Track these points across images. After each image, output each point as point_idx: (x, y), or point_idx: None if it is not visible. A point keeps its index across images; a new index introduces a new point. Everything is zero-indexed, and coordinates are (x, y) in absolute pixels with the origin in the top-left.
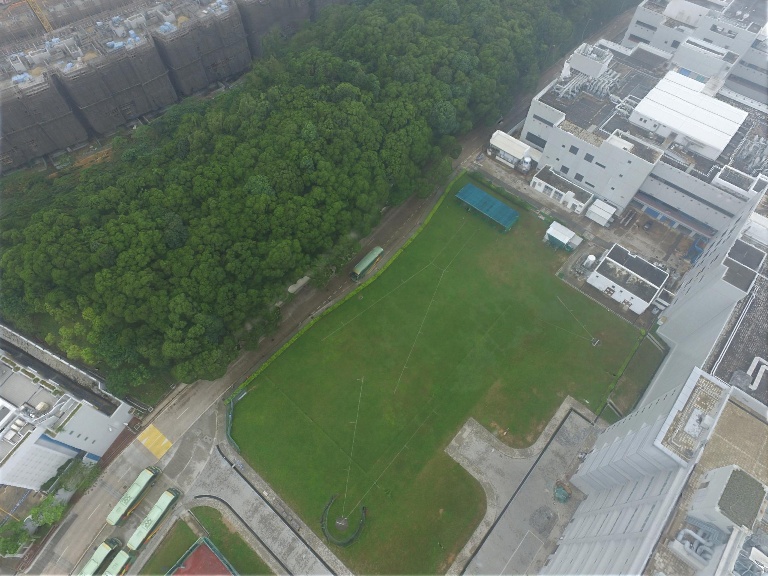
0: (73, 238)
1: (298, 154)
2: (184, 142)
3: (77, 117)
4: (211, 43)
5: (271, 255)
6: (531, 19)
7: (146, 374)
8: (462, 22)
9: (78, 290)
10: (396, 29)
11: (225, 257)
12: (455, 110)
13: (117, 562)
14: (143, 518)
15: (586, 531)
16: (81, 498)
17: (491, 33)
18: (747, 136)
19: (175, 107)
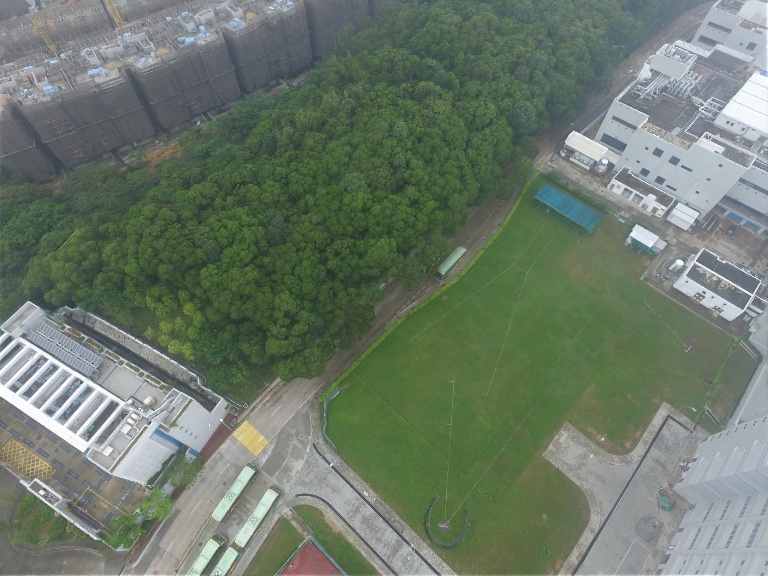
0: (178, 233)
1: (391, 152)
2: (271, 138)
3: (146, 112)
4: (276, 40)
5: (370, 254)
6: (603, 19)
7: (246, 371)
8: (536, 21)
9: (180, 285)
10: (472, 28)
11: (324, 255)
12: (535, 110)
13: (227, 559)
14: (245, 515)
15: (707, 542)
16: (182, 493)
17: (567, 33)
18: None
19: (243, 103)
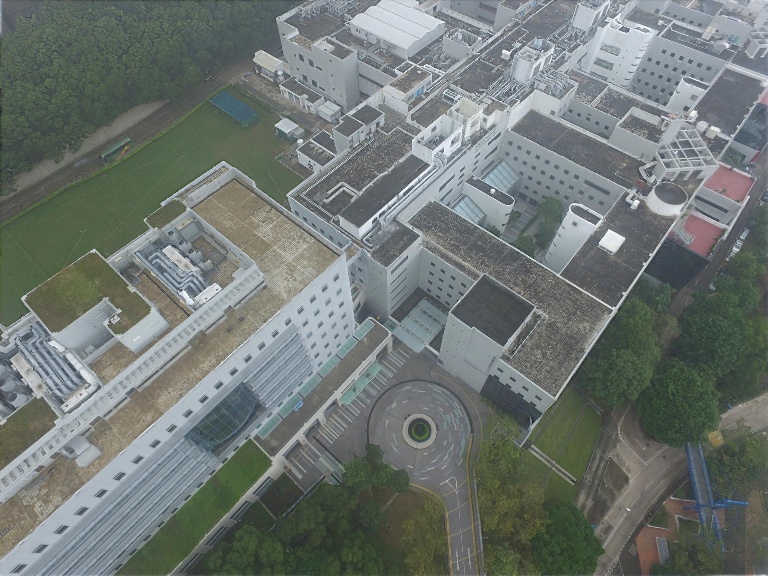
0: None
1: (36, 53)
2: None
3: None
4: None
5: None
6: None
7: None
8: None
9: None
10: None
11: None
12: (209, 29)
13: None
14: None
15: None
16: None
17: None
18: None
19: None
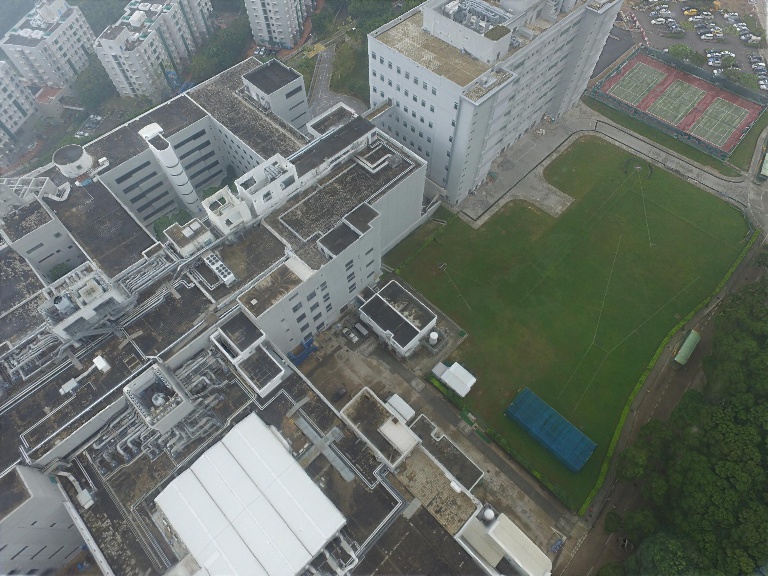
0: None
1: None
2: None
3: None
4: None
5: None
6: None
7: None
8: None
9: None
10: None
11: None
12: None
13: None
14: None
15: None
16: None
17: None
18: (171, 472)
19: None
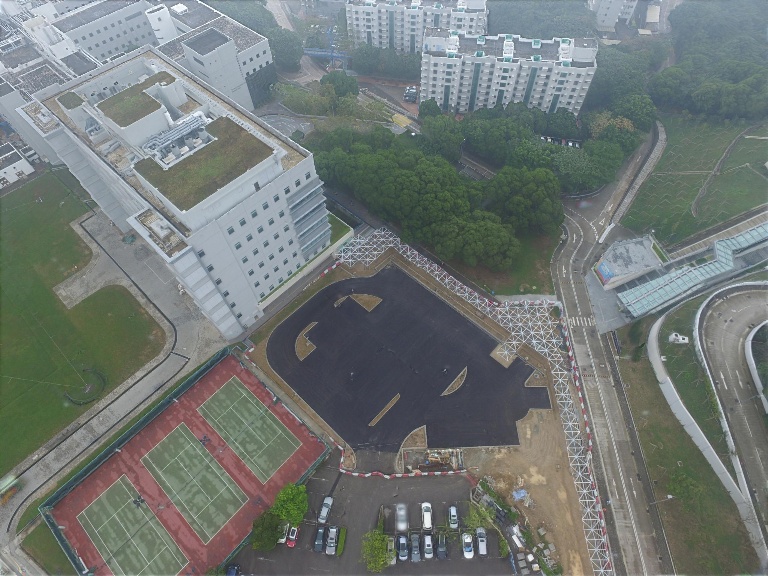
0: None
1: None
2: None
3: None
4: None
5: None
6: None
7: None
8: None
9: None
10: None
11: None
12: None
13: None
14: None
15: None
16: None
17: None
18: None
19: None
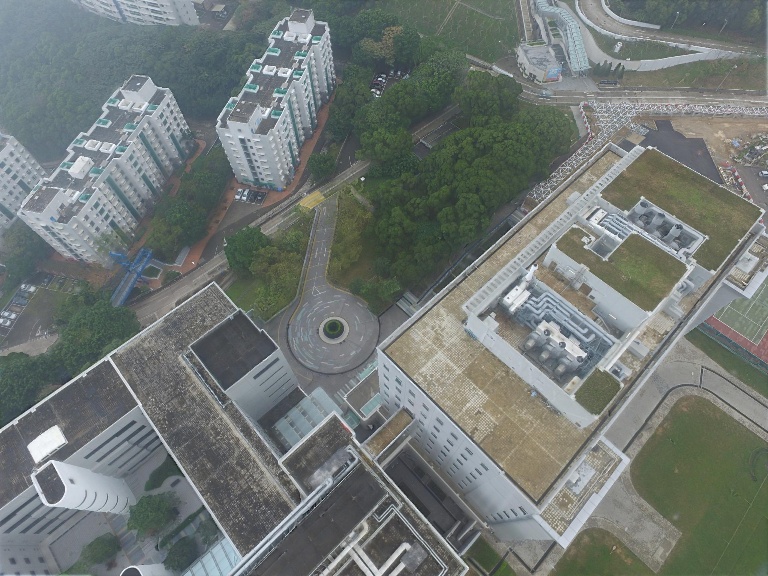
0: None
1: None
2: None
3: None
4: None
5: None
6: None
7: None
8: None
9: None
10: None
11: None
12: None
13: None
14: None
15: None
16: None
17: None
18: None
19: None
